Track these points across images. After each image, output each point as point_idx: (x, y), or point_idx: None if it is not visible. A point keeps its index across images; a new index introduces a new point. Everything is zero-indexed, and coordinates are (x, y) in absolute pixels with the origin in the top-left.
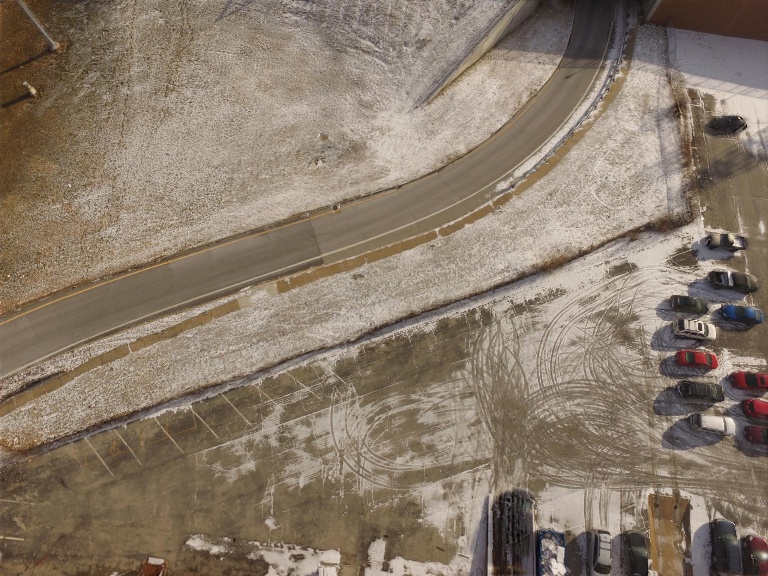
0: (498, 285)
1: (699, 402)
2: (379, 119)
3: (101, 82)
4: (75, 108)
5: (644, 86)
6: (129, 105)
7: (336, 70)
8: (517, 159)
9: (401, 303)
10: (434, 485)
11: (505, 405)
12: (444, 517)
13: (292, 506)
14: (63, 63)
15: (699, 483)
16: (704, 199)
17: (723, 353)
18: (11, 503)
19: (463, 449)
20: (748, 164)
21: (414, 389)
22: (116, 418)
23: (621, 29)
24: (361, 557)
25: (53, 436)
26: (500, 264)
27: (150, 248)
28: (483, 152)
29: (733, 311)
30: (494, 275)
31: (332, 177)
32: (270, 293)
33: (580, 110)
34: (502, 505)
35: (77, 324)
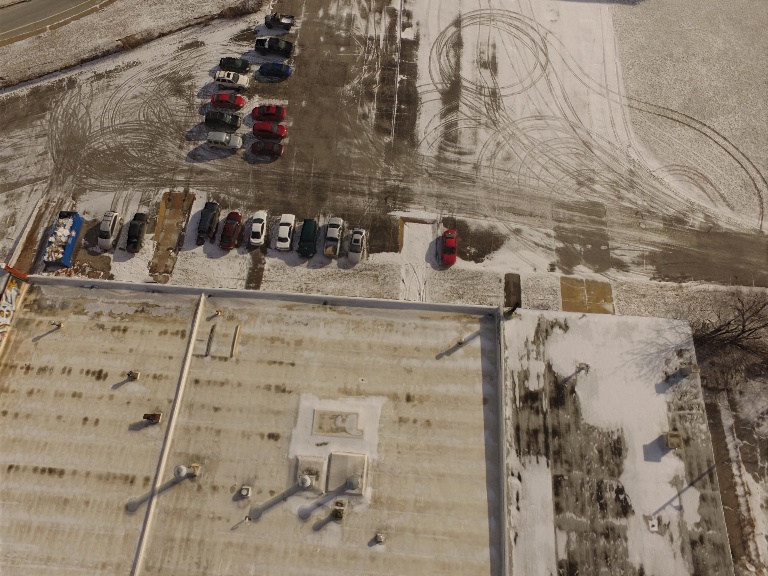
0: (84, 60)
1: (224, 131)
2: None
3: None
4: None
5: None
6: None
7: None
8: None
9: None
10: None
11: (69, 141)
12: (2, 215)
13: None
14: None
15: (206, 183)
16: None
17: (254, 98)
18: None
19: (29, 171)
20: None
21: (0, 134)
22: None
23: None
24: None
25: None
26: (91, 46)
27: None
28: None
29: (266, 66)
30: (84, 54)
31: None
32: None
33: None
34: (48, 205)
35: None
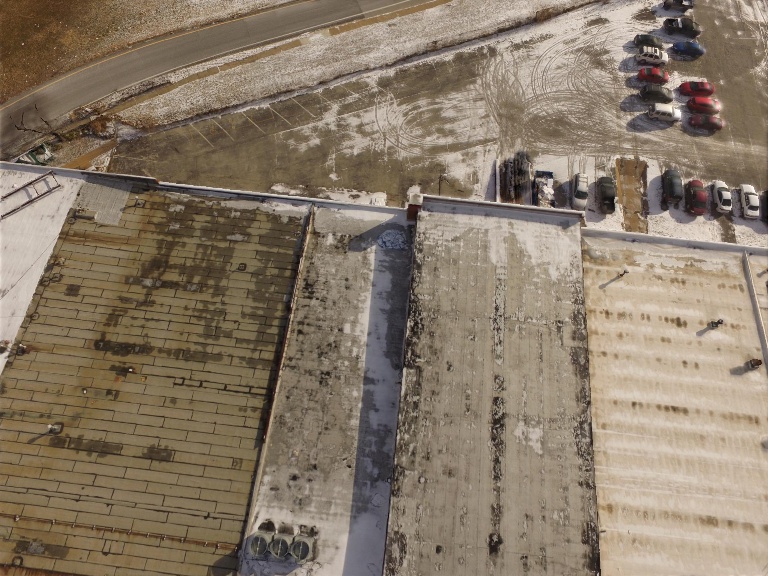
0: (501, 30)
1: None
2: None
3: None
4: None
5: None
6: None
7: None
8: None
9: (426, 41)
10: (455, 154)
11: (507, 106)
12: (463, 173)
13: (349, 166)
14: None
15: (654, 152)
16: None
17: (674, 74)
18: (139, 160)
19: (476, 132)
20: None
21: (438, 96)
22: (213, 110)
23: None
24: (402, 196)
25: (166, 121)
26: (502, 17)
27: (228, 9)
28: None
29: (682, 45)
30: (498, 24)
31: None
32: (324, 35)
33: None
34: (506, 165)
35: (176, 56)
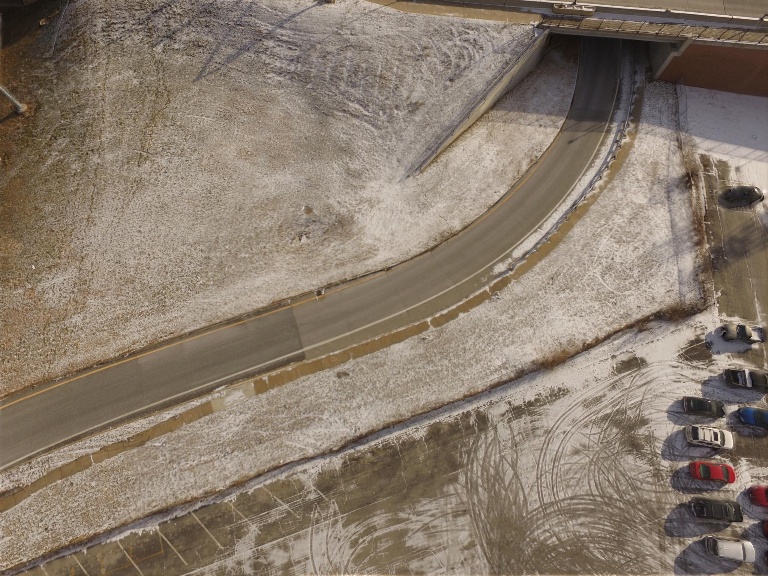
0: (495, 385)
1: (715, 521)
2: (368, 190)
3: (70, 149)
4: (42, 178)
5: (653, 152)
6: (99, 175)
7: (322, 135)
8: (516, 237)
9: (389, 406)
10: None
11: (502, 525)
12: None
13: None
14: (30, 127)
15: None
16: (718, 282)
17: (741, 463)
18: None
19: None
20: (765, 241)
21: (402, 506)
22: (75, 542)
23: (628, 87)
24: None
25: (5, 564)
26: (497, 360)
27: (118, 341)
28: (479, 228)
29: (751, 415)
30: (490, 373)
31: (316, 257)
32: (246, 394)
33: (584, 180)
34: None
35: (36, 430)
